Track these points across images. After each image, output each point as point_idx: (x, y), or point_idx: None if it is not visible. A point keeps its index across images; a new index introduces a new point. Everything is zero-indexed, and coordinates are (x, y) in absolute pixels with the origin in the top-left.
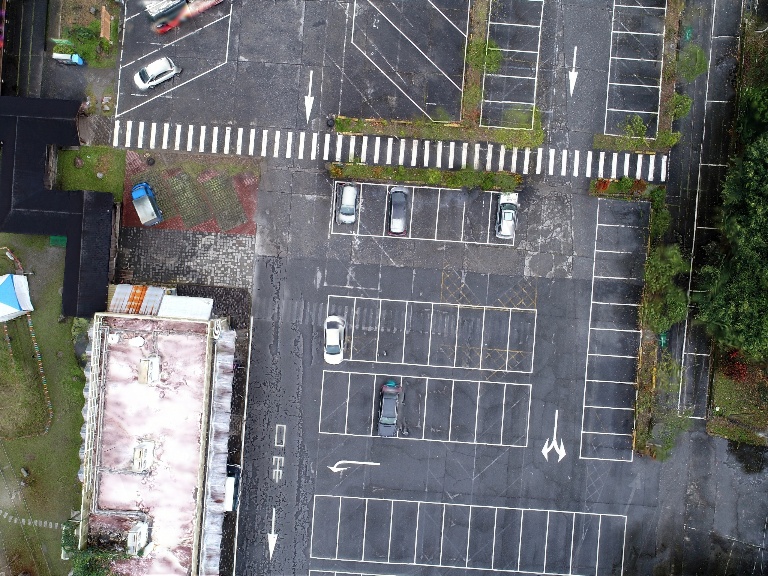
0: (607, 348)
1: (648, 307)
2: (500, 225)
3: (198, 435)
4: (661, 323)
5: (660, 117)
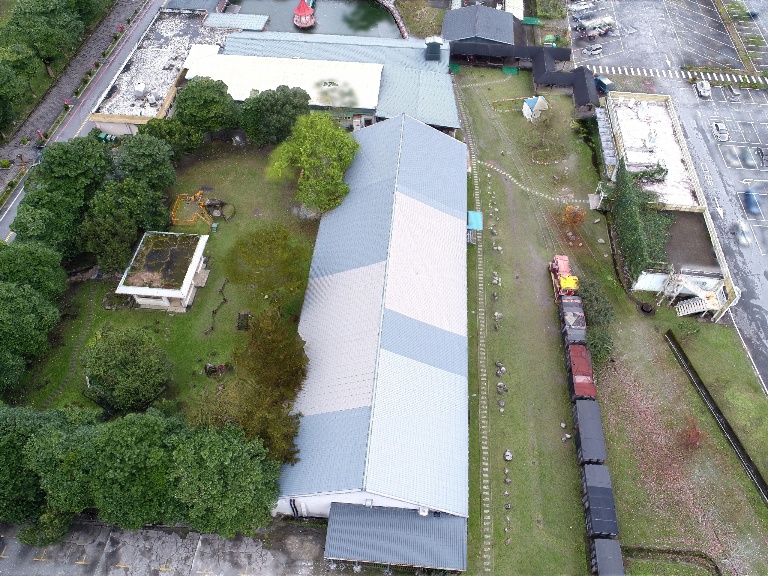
0: None
1: None
2: None
3: (674, 139)
4: None
5: None
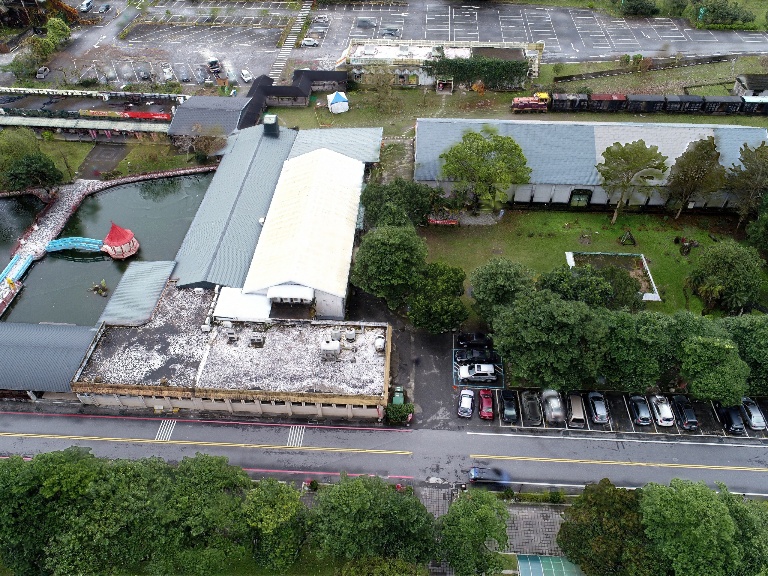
0: (369, 8)
1: (356, 3)
2: (323, 17)
3: None
4: None
5: (291, 2)
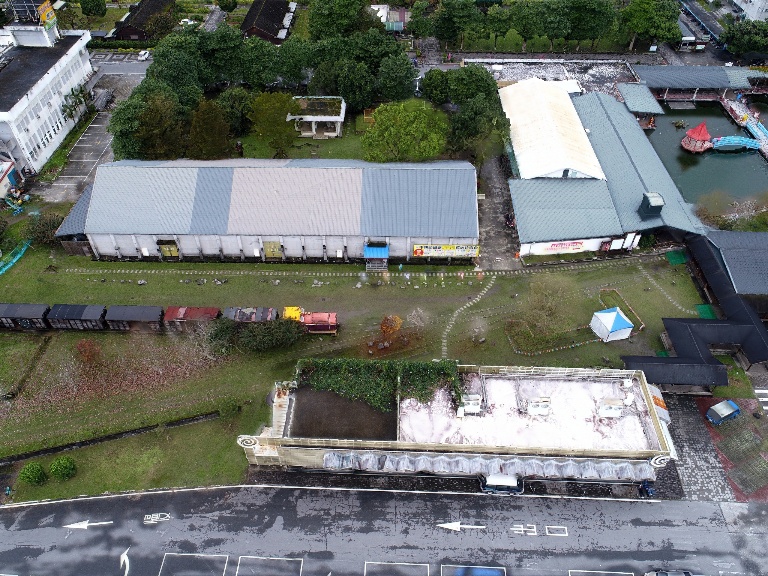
0: None
1: None
2: None
3: None
4: None
5: None
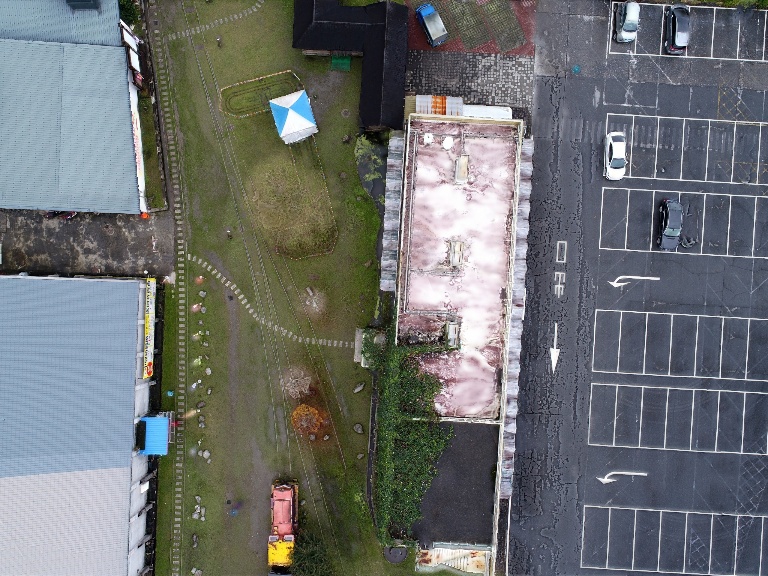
0: None
1: None
2: None
3: (504, 237)
4: None
5: None
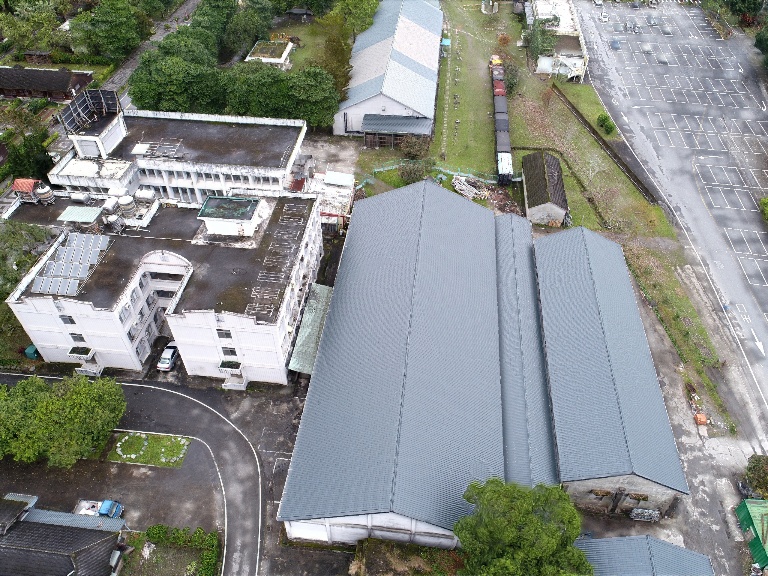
0: None
1: None
2: None
3: None
4: (715, 3)
5: None
